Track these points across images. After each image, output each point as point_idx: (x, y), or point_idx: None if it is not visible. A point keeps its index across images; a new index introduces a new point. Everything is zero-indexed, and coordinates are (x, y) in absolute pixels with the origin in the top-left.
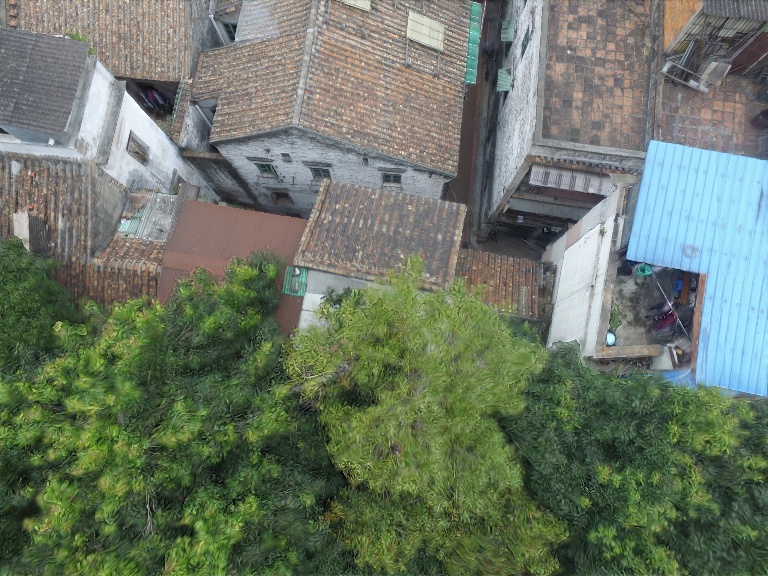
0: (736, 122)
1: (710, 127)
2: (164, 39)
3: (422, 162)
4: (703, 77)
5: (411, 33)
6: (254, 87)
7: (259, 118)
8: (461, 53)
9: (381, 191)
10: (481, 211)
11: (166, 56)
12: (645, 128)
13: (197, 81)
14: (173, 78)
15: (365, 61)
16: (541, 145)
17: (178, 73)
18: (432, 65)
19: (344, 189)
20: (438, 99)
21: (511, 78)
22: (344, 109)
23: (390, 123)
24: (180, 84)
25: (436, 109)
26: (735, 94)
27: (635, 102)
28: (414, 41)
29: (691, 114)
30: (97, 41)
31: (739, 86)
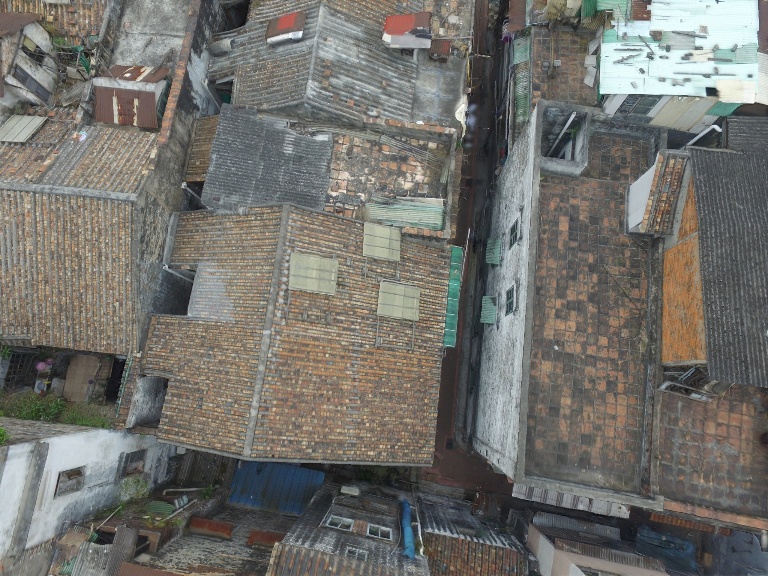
0: (743, 439)
1: (714, 444)
2: (109, 312)
3: (393, 459)
4: (706, 390)
5: (382, 308)
6: (206, 383)
7: (209, 429)
8: (439, 313)
9: (340, 559)
10: (467, 411)
11: (112, 329)
12: (641, 446)
13: (147, 352)
14: (120, 351)
15: (329, 353)
16: (523, 484)
17: (125, 346)
18: (406, 336)
19: (298, 559)
20: (412, 376)
21: (496, 311)
22: (304, 418)
23: (357, 421)
24: (128, 358)
25: (410, 389)
26: (742, 404)
27: (630, 412)
28: (385, 317)
29: (692, 428)
30: (36, 313)
31: (746, 394)
